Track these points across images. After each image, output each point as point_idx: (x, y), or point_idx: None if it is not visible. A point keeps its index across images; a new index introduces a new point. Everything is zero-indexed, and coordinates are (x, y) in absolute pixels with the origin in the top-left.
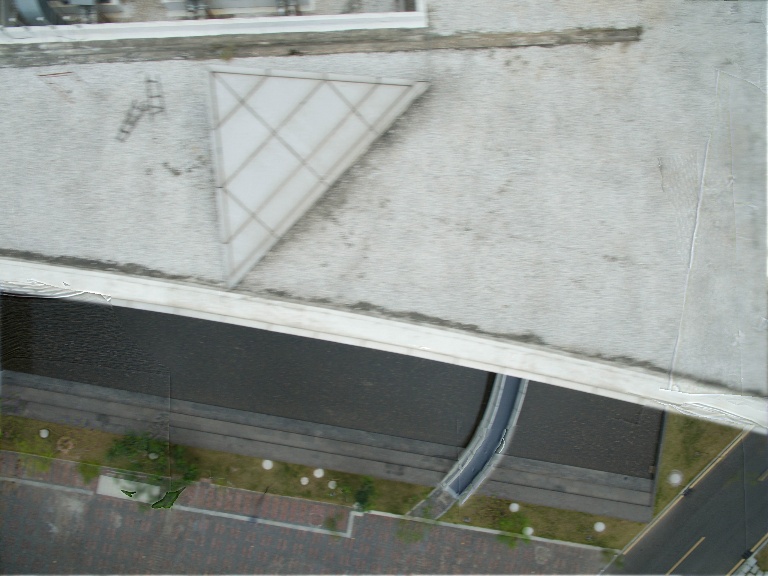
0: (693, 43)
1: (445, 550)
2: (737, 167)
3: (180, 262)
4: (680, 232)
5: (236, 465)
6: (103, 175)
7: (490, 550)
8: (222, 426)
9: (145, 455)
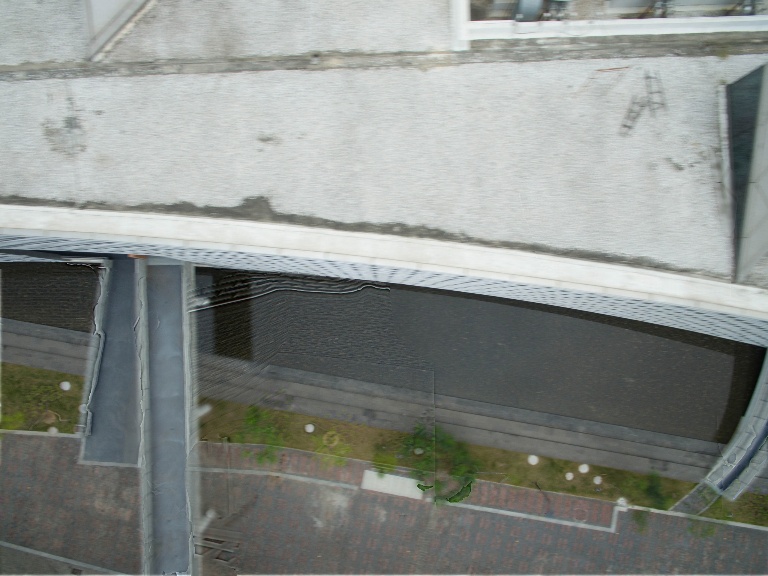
0: None
1: (708, 545)
2: None
3: (692, 255)
4: None
5: (502, 460)
6: (613, 169)
7: (752, 545)
8: (487, 421)
9: (410, 450)
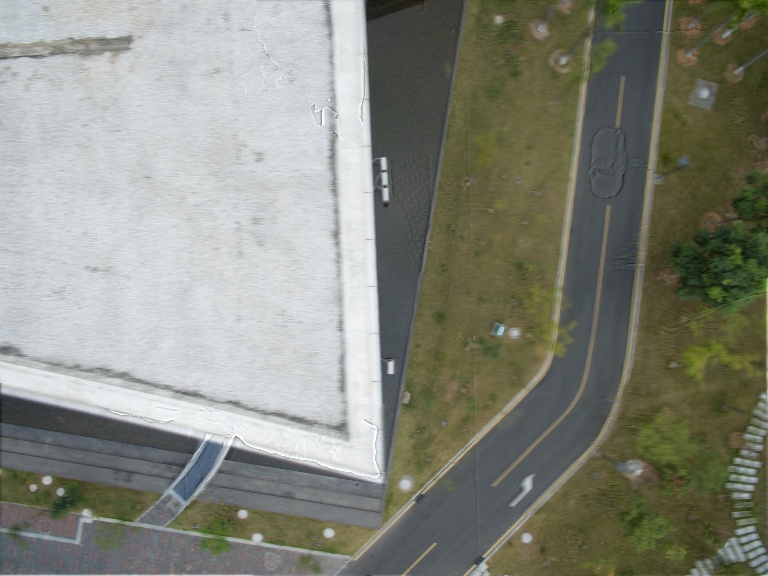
0: (178, 52)
1: (174, 556)
2: (474, 170)
3: None
4: (411, 236)
5: None
6: None
7: (220, 556)
8: None
9: None
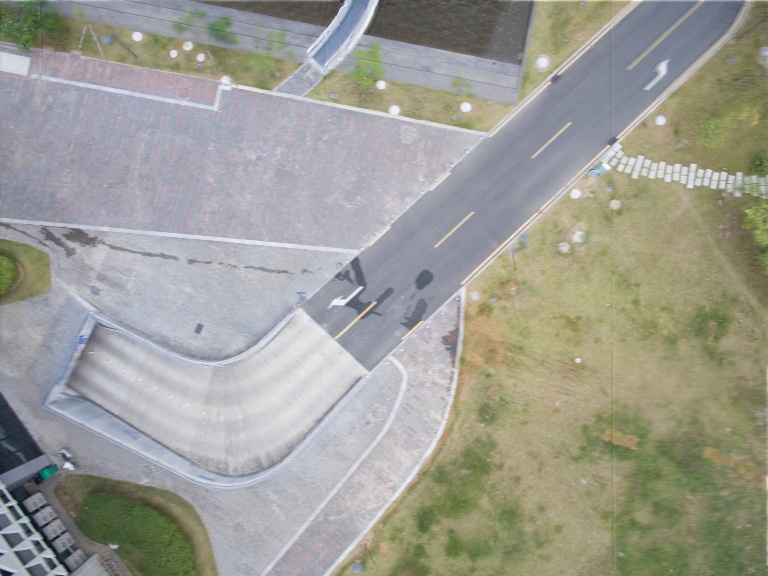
0: None
1: (311, 126)
2: None
3: None
4: None
5: (106, 36)
6: None
7: (356, 128)
8: None
9: None
